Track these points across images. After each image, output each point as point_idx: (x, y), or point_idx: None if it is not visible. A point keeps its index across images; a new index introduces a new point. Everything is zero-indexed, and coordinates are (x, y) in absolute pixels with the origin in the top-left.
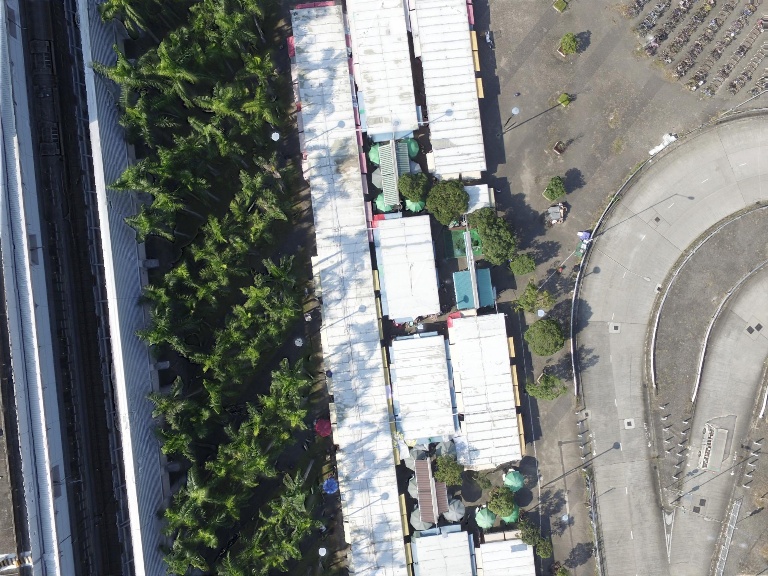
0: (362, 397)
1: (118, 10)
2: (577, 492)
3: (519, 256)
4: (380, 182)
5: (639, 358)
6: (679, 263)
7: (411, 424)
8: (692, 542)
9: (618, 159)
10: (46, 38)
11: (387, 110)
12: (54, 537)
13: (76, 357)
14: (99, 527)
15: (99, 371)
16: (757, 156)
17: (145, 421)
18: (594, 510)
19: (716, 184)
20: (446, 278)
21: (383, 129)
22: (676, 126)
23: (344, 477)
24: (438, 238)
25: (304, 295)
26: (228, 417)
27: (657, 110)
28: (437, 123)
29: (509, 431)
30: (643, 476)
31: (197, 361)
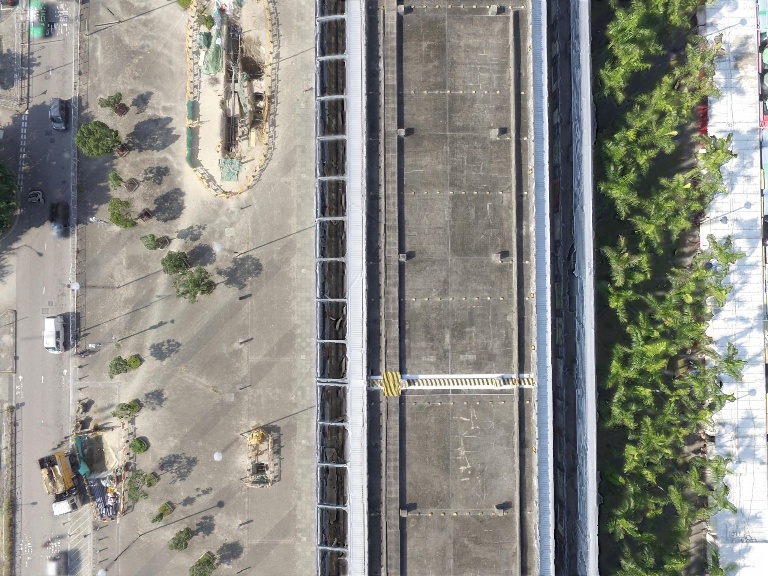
0: (739, 292)
1: None
2: None
3: None
4: None
5: None
6: None
7: None
8: None
9: None
10: None
11: None
12: (549, 363)
13: None
14: None
15: None
16: None
17: None
18: None
19: None
20: None
21: None
22: None
23: None
24: None
25: None
26: (641, 288)
27: None
28: None
29: None
30: None
31: (637, 224)
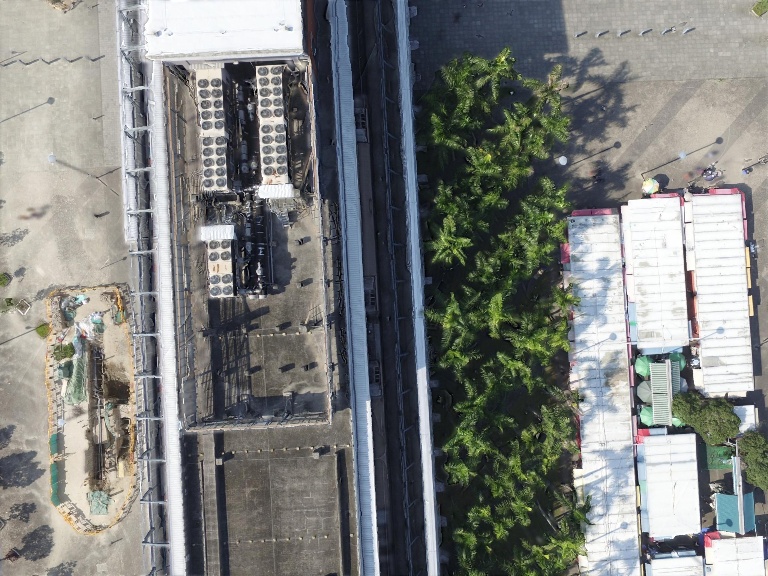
0: None
1: (450, 253)
2: None
3: None
4: (648, 397)
5: None
6: None
7: None
8: None
9: None
10: (371, 273)
11: (659, 325)
12: None
13: None
14: None
15: None
16: None
17: None
18: None
19: None
20: None
21: (654, 344)
22: None
23: None
24: None
25: (556, 500)
26: None
27: None
28: (708, 340)
29: None
30: None
31: None
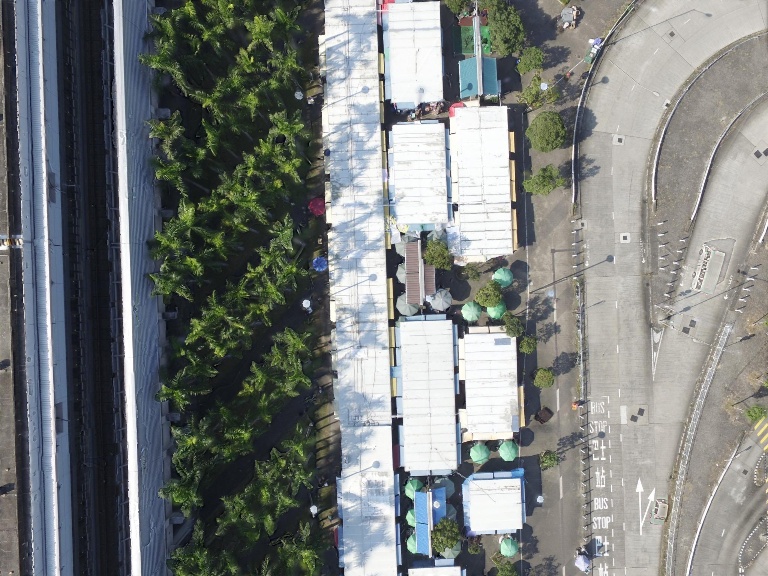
0: (358, 177)
1: None
2: (566, 301)
3: (527, 48)
4: None
5: (641, 173)
6: (690, 80)
7: (405, 208)
8: (678, 362)
9: None
10: None
11: None
12: (45, 223)
13: (80, 91)
14: (90, 260)
15: (101, 110)
16: None
17: (143, 167)
18: (582, 320)
19: (736, 3)
20: (452, 74)
21: None
22: None
23: (334, 255)
24: (447, 30)
25: (309, 80)
26: (224, 168)
27: None
28: None
29: (502, 224)
30: (634, 291)
31: (197, 99)
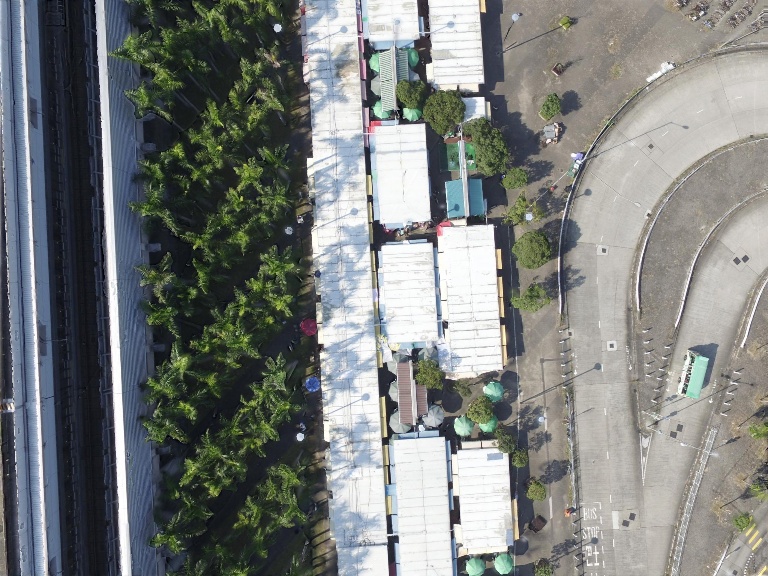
0: (349, 298)
1: None
2: (556, 409)
3: None
4: (379, 89)
5: (625, 282)
6: (670, 190)
7: (396, 328)
8: (667, 466)
9: (615, 84)
10: None
11: (390, 18)
12: (37, 386)
13: (69, 231)
14: (82, 399)
15: (91, 247)
16: (753, 90)
17: (134, 301)
18: (572, 428)
19: (711, 115)
20: (439, 190)
21: (385, 37)
22: (675, 55)
23: (327, 376)
24: (433, 149)
25: (298, 199)
26: (215, 301)
27: (657, 38)
28: (438, 34)
29: (492, 341)
30: (622, 398)
31: (188, 239)
